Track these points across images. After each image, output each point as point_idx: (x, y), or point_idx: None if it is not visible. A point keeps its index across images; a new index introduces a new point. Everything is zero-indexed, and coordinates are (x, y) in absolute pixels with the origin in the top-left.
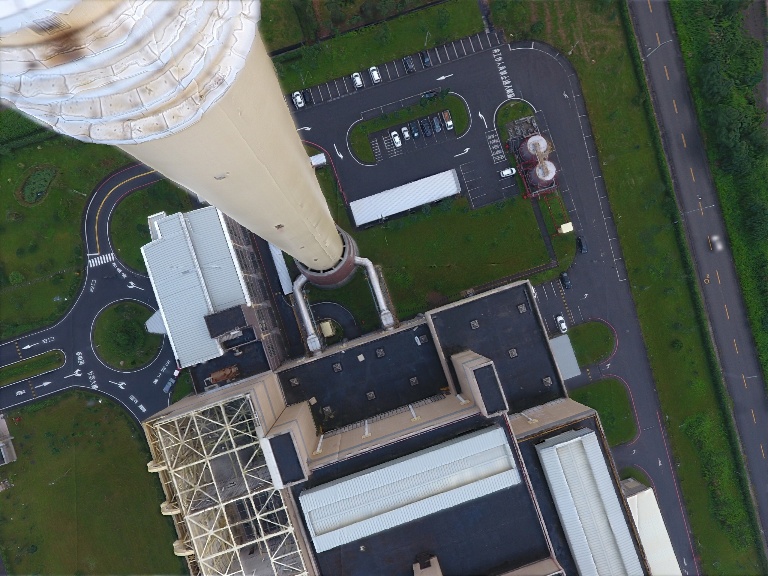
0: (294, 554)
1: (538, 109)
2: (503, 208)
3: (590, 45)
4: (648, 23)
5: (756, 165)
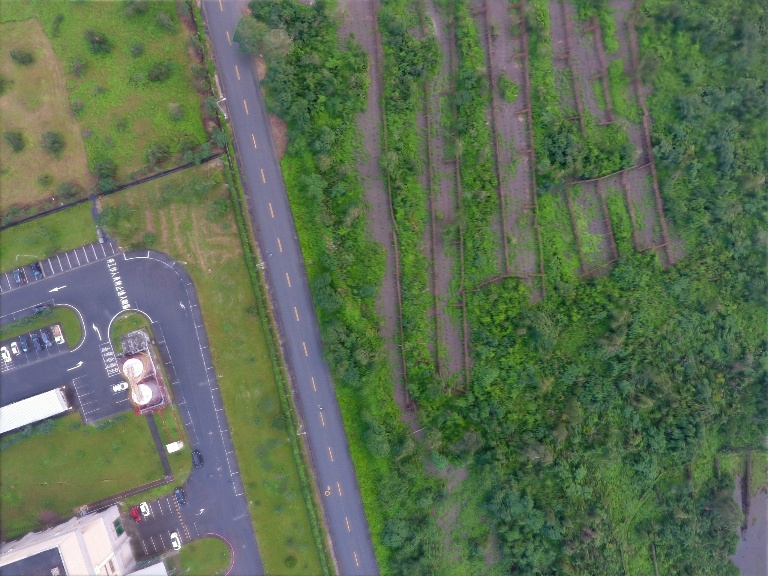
0: None
1: (154, 320)
2: (116, 423)
3: (206, 254)
4: (269, 228)
5: (366, 381)
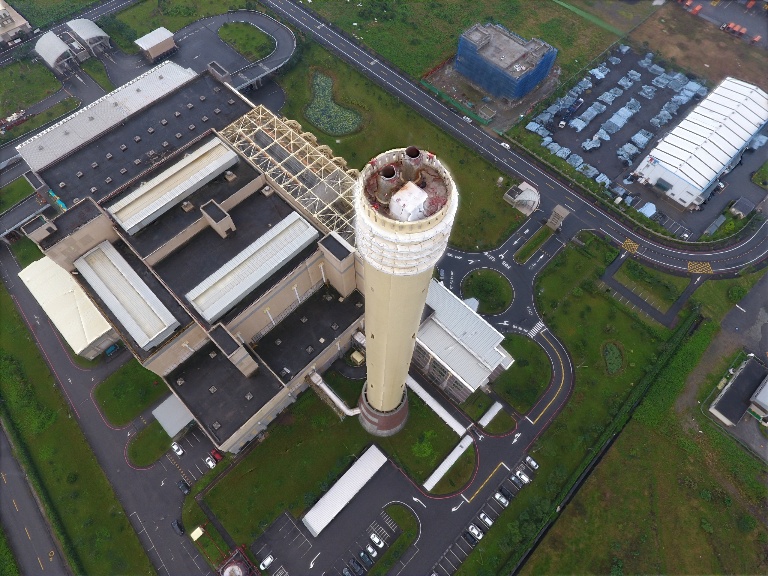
0: (308, 209)
1: None
2: None
3: None
4: None
5: None
